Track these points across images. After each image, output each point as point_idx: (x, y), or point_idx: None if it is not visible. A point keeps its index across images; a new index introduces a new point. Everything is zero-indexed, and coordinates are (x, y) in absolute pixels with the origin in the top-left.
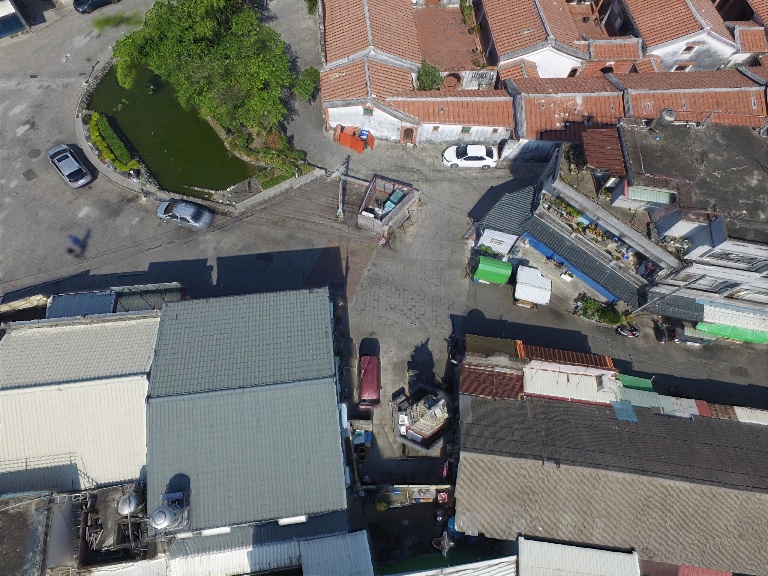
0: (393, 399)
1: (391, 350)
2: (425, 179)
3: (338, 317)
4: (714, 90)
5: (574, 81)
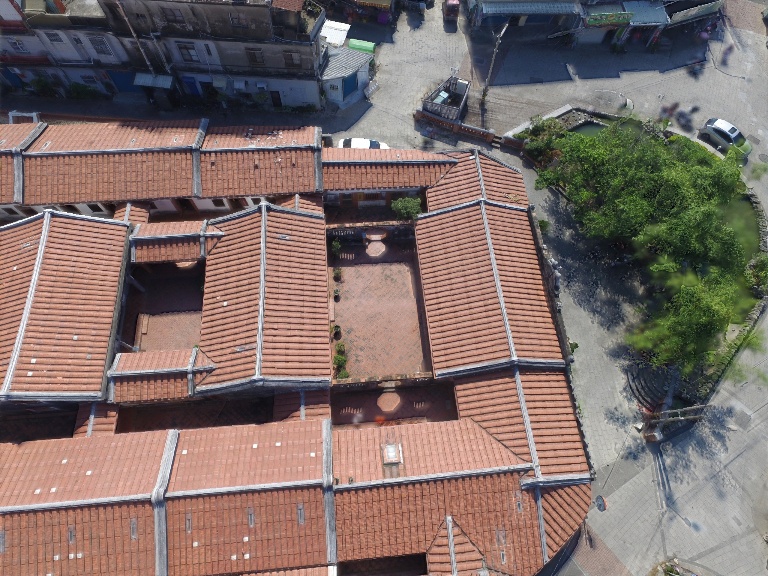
0: (434, 4)
1: (436, 27)
2: (408, 139)
3: (474, 44)
4: (89, 150)
5: (244, 183)
